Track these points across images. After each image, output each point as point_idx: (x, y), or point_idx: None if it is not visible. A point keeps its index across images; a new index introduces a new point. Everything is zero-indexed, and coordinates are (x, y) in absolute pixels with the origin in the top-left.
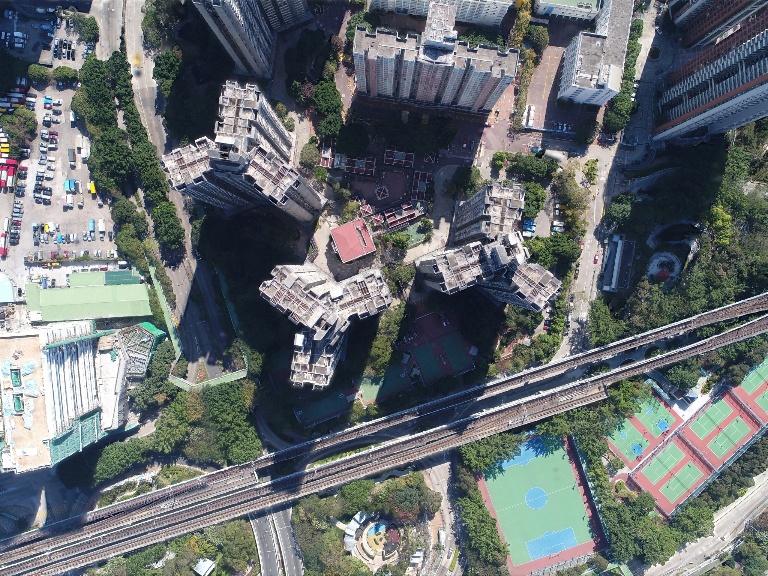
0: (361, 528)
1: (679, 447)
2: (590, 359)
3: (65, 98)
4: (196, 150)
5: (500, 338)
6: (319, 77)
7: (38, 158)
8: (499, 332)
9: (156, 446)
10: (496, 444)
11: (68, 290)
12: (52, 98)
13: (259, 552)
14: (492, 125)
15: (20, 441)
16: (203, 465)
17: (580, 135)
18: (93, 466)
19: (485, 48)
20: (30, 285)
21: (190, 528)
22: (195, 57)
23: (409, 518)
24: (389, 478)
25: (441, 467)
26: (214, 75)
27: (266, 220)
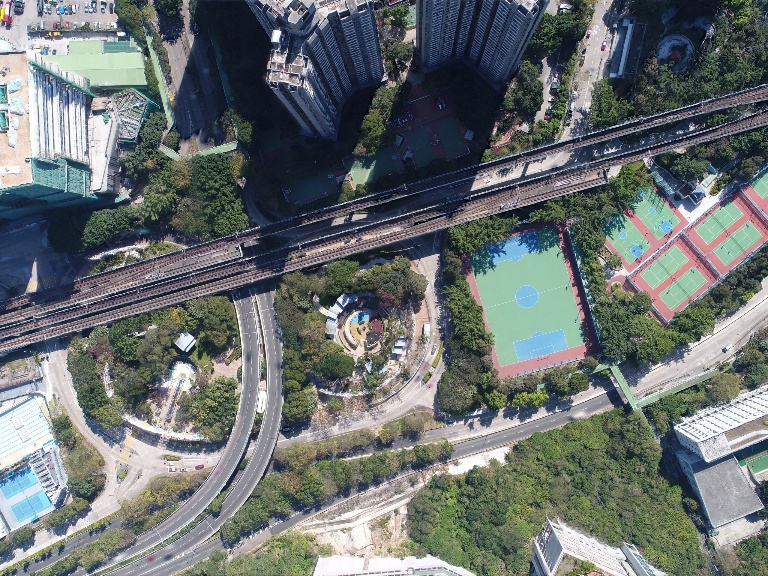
0: (344, 315)
1: (682, 251)
2: (590, 142)
3: None
4: None
5: (498, 125)
6: None
7: None
8: (497, 118)
9: (143, 212)
10: (486, 225)
11: (67, 56)
12: None
13: (241, 333)
14: None
15: (4, 159)
16: (190, 243)
17: None
18: (81, 228)
19: None
20: None
21: (173, 301)
22: None
23: (393, 302)
24: None
25: (430, 259)
26: None
27: None
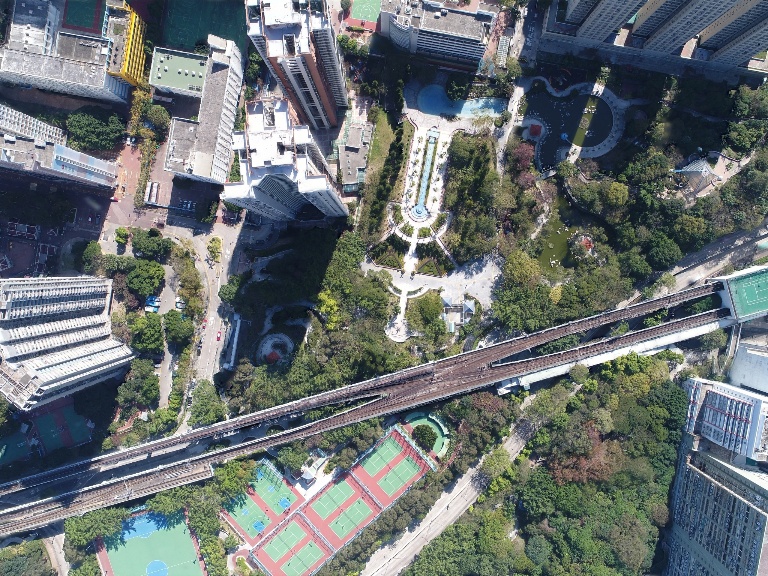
0: None
1: (301, 526)
2: (195, 438)
3: None
4: None
5: None
6: None
7: None
8: (120, 405)
9: None
10: (96, 519)
11: None
12: None
13: None
14: (119, 200)
15: None
16: None
17: (197, 214)
18: None
19: (23, 140)
20: None
21: None
22: None
23: None
24: (10, 545)
25: (64, 536)
26: None
27: None
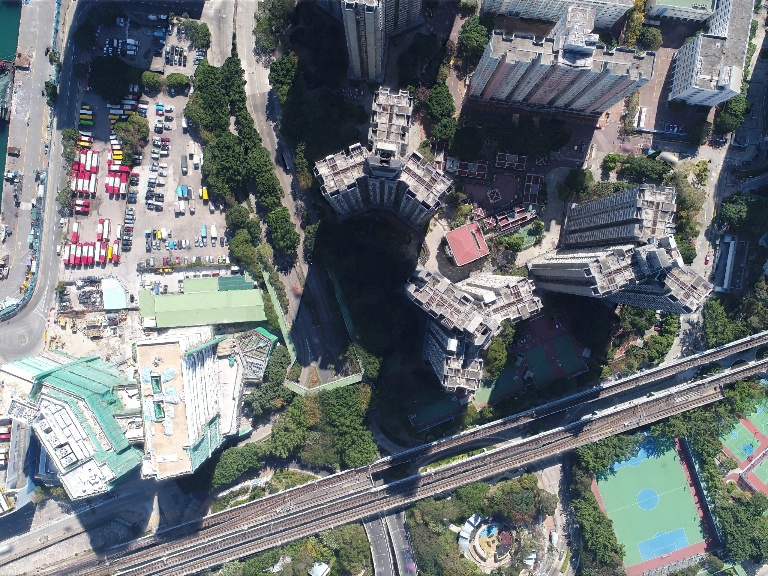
0: (474, 530)
1: None
2: (706, 360)
3: (177, 104)
4: (349, 156)
5: (612, 340)
6: (431, 81)
7: (150, 165)
8: (611, 334)
9: (273, 451)
10: (614, 446)
11: (183, 296)
12: (164, 105)
13: (373, 555)
14: (602, 127)
15: (160, 448)
16: (316, 469)
17: (693, 136)
18: (212, 471)
19: (621, 51)
20: (143, 291)
21: (306, 532)
22: (309, 62)
23: (524, 520)
24: (501, 480)
25: (552, 469)
26: (329, 80)
27: (380, 224)
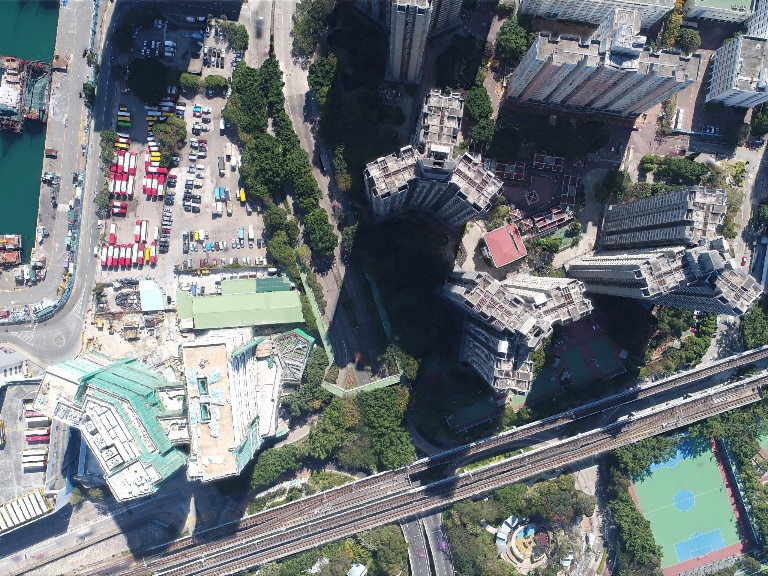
0: (511, 532)
1: None
2: (744, 361)
3: (214, 106)
4: (401, 159)
5: (649, 341)
6: (469, 82)
7: (187, 166)
8: (648, 335)
9: (312, 452)
10: (652, 447)
11: (221, 298)
12: (201, 106)
13: (409, 556)
14: (639, 128)
15: (206, 449)
16: (352, 470)
17: (731, 138)
18: (250, 473)
19: (667, 53)
20: (181, 293)
21: (343, 533)
22: (347, 64)
23: (562, 521)
24: (538, 482)
25: (589, 470)
26: (368, 82)
27: (418, 226)
